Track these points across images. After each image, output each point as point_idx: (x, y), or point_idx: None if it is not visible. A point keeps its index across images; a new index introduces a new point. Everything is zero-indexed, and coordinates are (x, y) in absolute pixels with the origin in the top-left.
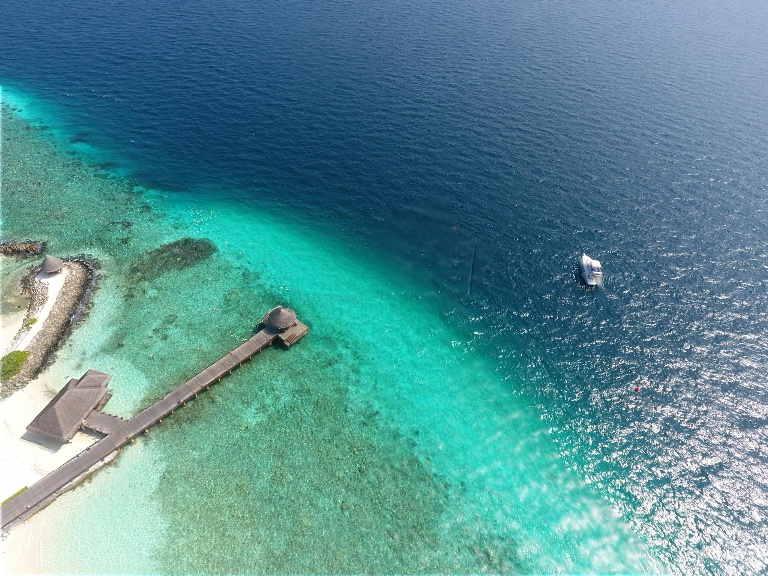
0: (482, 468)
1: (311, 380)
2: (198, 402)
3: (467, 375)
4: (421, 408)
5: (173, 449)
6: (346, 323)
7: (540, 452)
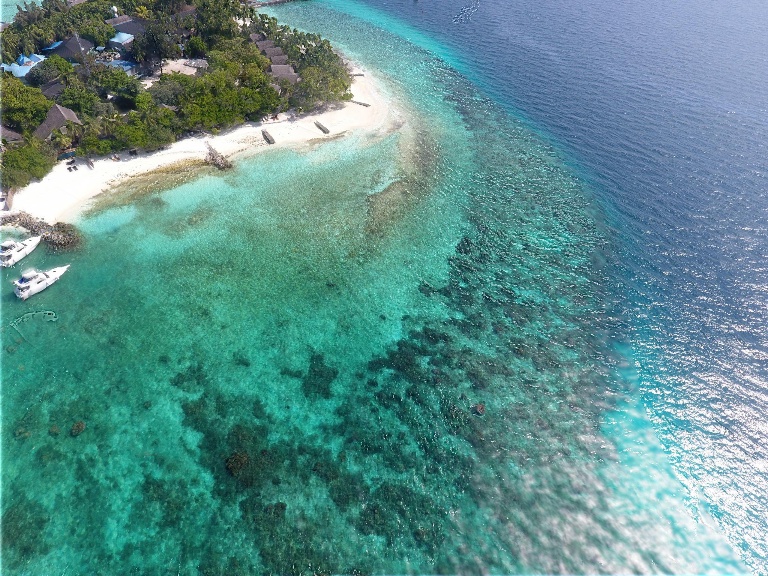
0: (366, 17)
1: (315, 5)
2: (280, 4)
3: (367, 10)
4: (350, 11)
5: (276, 8)
6: (326, 0)
7: (385, 18)
